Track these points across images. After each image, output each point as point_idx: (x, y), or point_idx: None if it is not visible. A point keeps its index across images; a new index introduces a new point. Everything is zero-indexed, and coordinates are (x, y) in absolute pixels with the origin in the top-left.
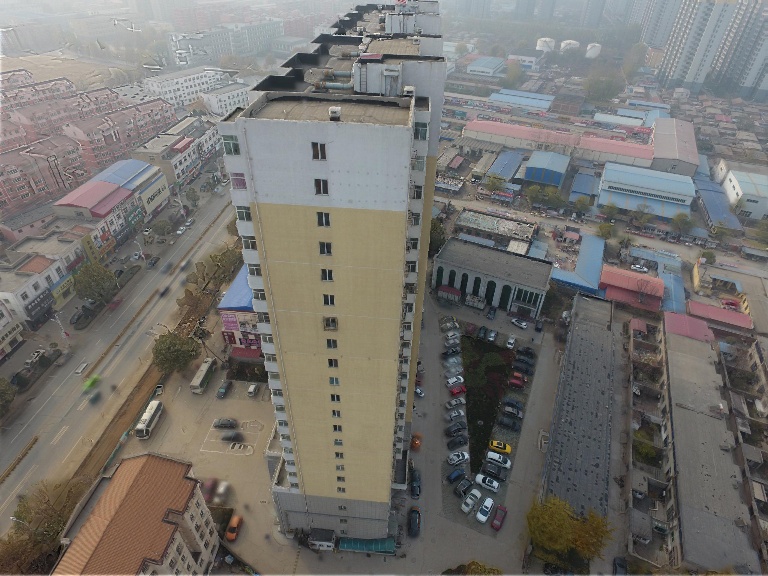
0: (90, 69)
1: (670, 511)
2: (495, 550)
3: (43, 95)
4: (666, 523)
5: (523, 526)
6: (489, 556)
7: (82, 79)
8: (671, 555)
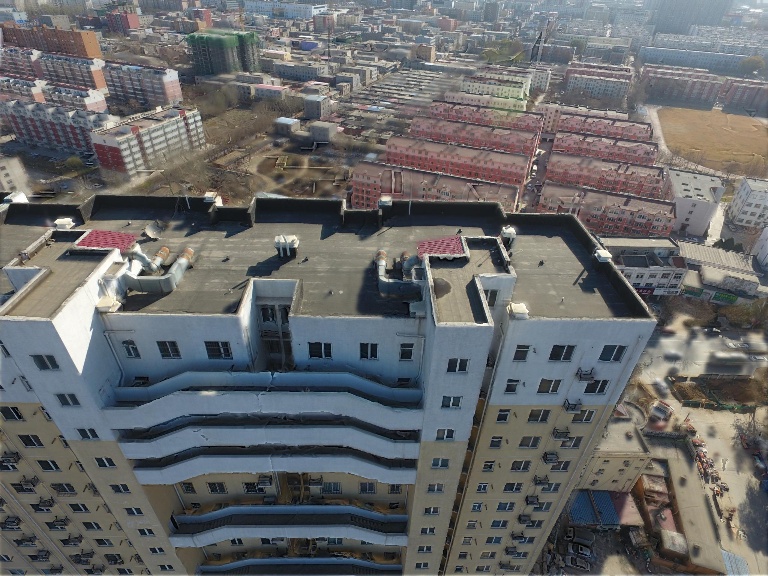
0: (766, 147)
1: None
2: None
3: (617, 151)
4: None
5: None
6: None
7: (706, 152)
8: None
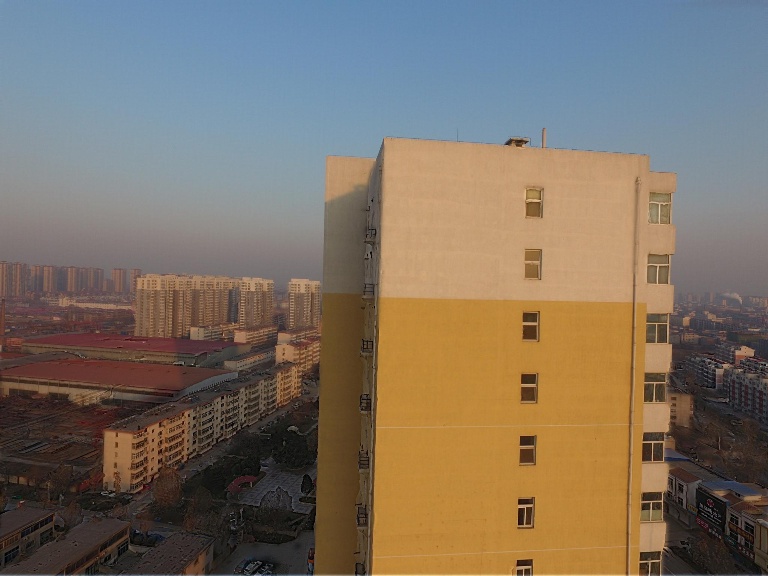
0: None
1: (88, 574)
2: (253, 554)
3: None
4: (103, 565)
5: (224, 567)
6: (258, 551)
7: None
8: (121, 550)
